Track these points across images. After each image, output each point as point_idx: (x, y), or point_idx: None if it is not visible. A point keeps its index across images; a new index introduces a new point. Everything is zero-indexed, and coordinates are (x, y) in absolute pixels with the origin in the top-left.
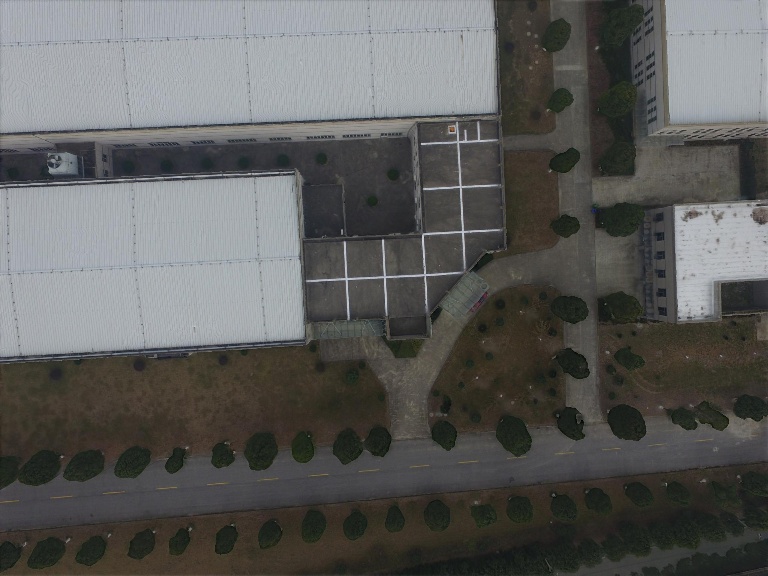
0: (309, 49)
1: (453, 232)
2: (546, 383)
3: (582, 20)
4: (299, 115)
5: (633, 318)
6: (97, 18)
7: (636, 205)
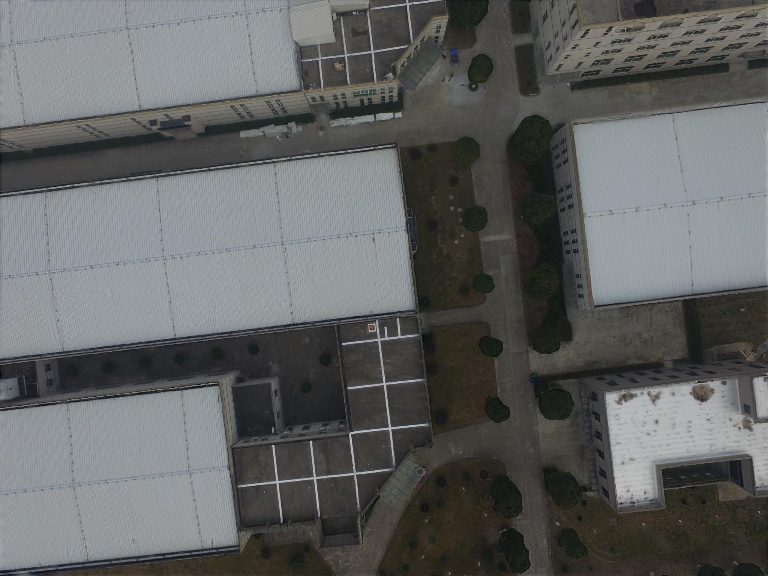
0: (225, 264)
1: (380, 429)
2: (496, 557)
3: (506, 189)
4: (220, 328)
5: (572, 507)
6: (26, 252)
7: (563, 396)
